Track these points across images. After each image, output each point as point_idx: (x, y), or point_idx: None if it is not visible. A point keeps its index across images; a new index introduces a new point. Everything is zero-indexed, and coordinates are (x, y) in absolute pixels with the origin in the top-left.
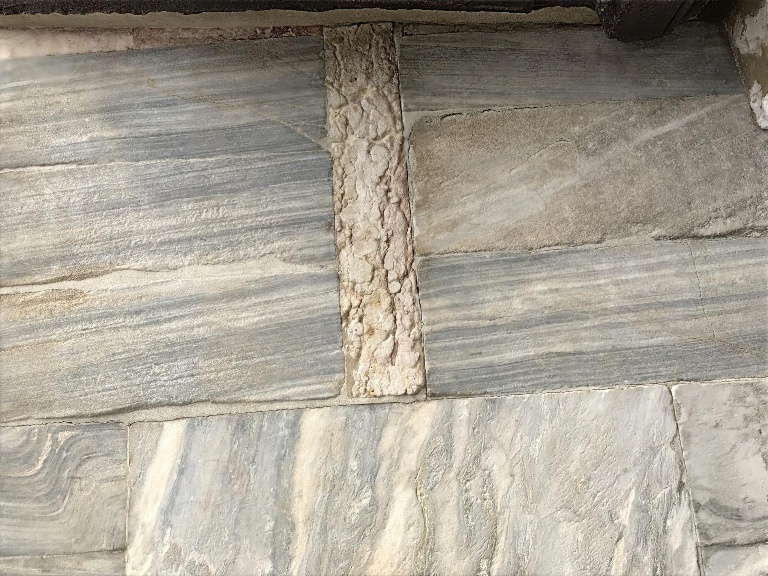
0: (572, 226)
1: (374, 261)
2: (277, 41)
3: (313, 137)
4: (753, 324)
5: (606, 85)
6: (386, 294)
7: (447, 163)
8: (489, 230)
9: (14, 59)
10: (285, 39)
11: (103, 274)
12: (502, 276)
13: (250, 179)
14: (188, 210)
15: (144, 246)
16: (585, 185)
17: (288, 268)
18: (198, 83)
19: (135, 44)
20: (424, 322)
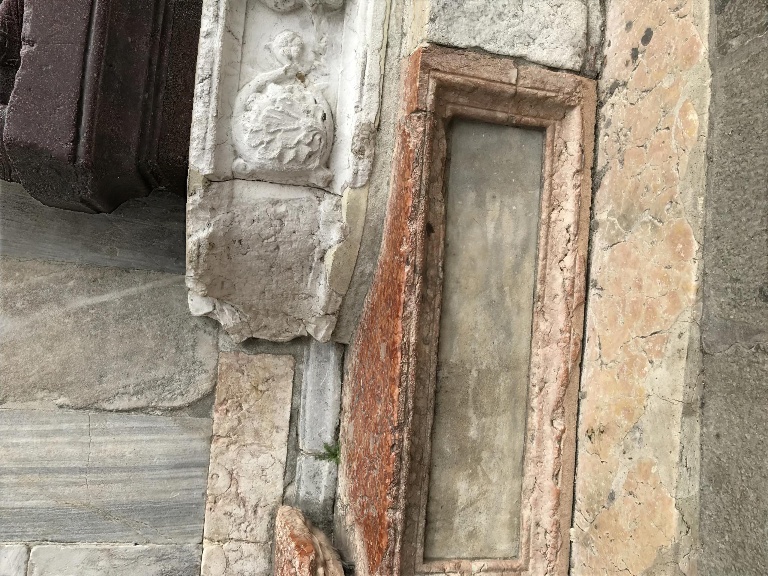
0: None
1: None
2: None
3: None
4: (130, 495)
5: (53, 243)
6: None
7: None
8: None
9: None
10: None
11: None
12: None
13: None
14: None
15: None
16: (1, 344)
17: None
18: None
19: None
20: None
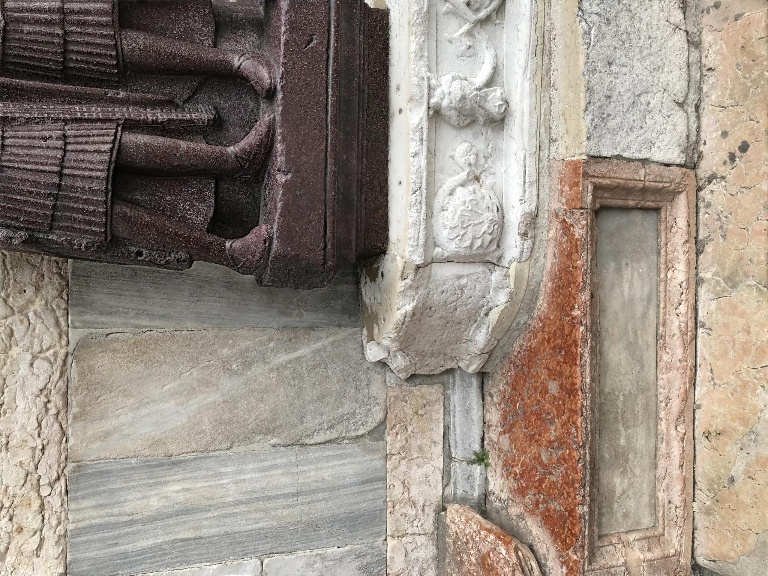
0: (208, 436)
1: (28, 467)
2: None
3: None
4: (331, 509)
5: (255, 313)
6: (36, 497)
7: (106, 379)
8: (137, 440)
9: None
10: None
11: None
12: (143, 479)
13: None
14: None
15: None
16: (224, 401)
17: None
18: None
19: None
20: (70, 520)
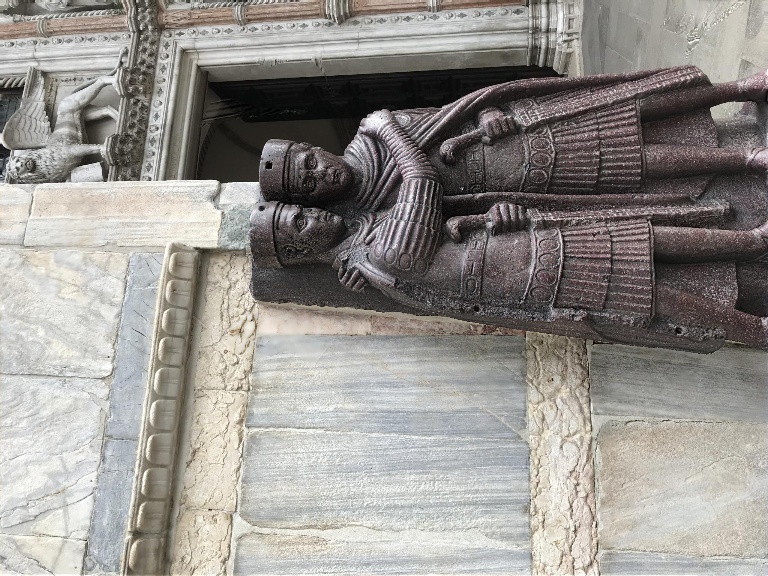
0: (741, 539)
1: (563, 548)
2: (487, 338)
3: (514, 427)
4: None
5: None
6: None
7: (629, 466)
8: (665, 533)
9: (280, 335)
10: (494, 337)
11: (341, 527)
12: None
13: (461, 459)
14: (410, 481)
15: (374, 508)
16: (754, 501)
17: (489, 543)
18: (421, 369)
19: (373, 330)
20: None
